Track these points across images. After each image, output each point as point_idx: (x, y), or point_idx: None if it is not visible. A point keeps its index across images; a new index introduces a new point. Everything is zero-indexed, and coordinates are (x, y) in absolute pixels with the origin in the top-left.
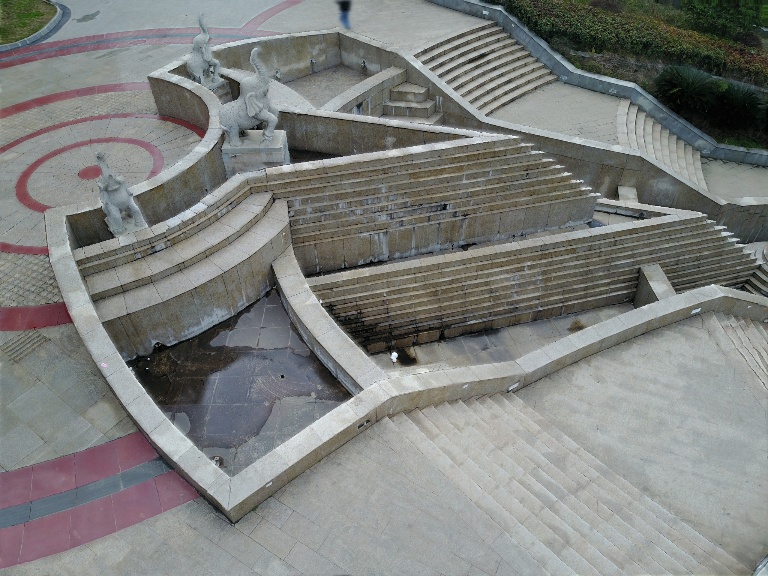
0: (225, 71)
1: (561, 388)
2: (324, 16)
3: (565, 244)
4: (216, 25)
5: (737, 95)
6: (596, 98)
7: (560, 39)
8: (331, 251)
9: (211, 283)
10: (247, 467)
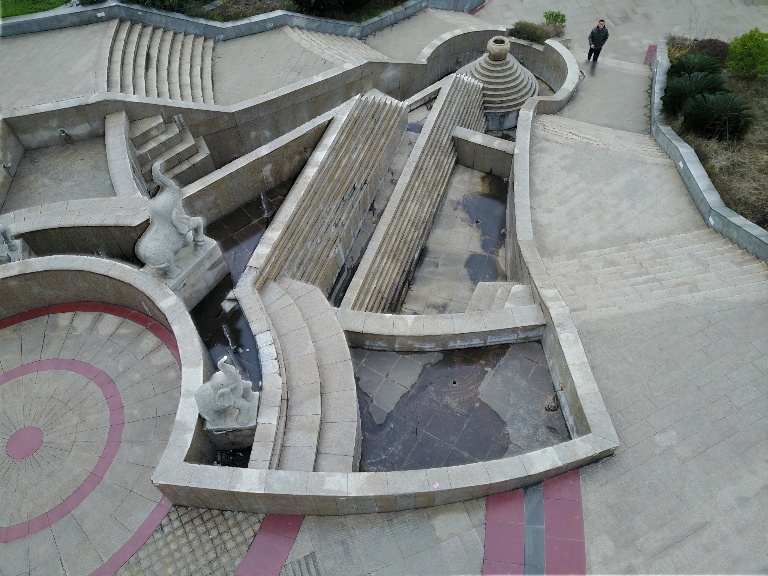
0: None
1: (544, 233)
2: None
3: (422, 153)
4: None
5: None
6: (264, 39)
7: (190, 4)
8: None
9: None
10: (587, 419)
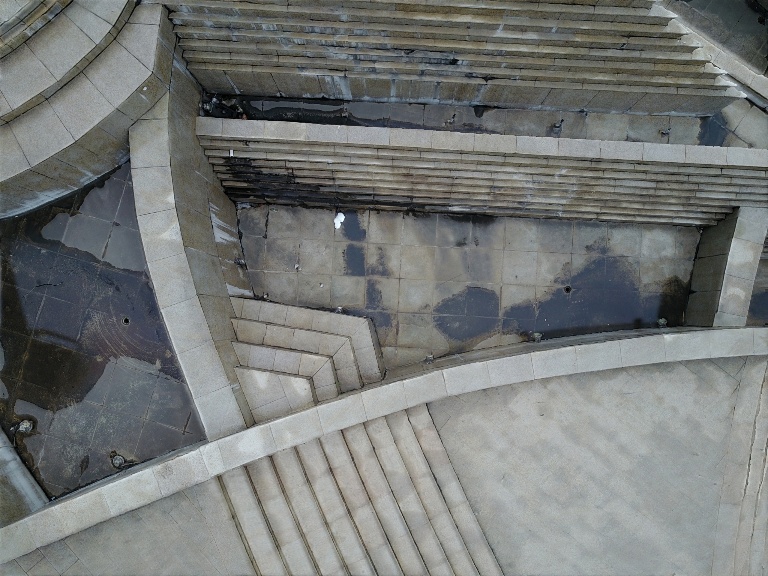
0: None
1: (491, 409)
2: None
3: (635, 162)
4: None
5: None
6: None
7: None
8: (254, 80)
9: (13, 178)
10: (18, 522)
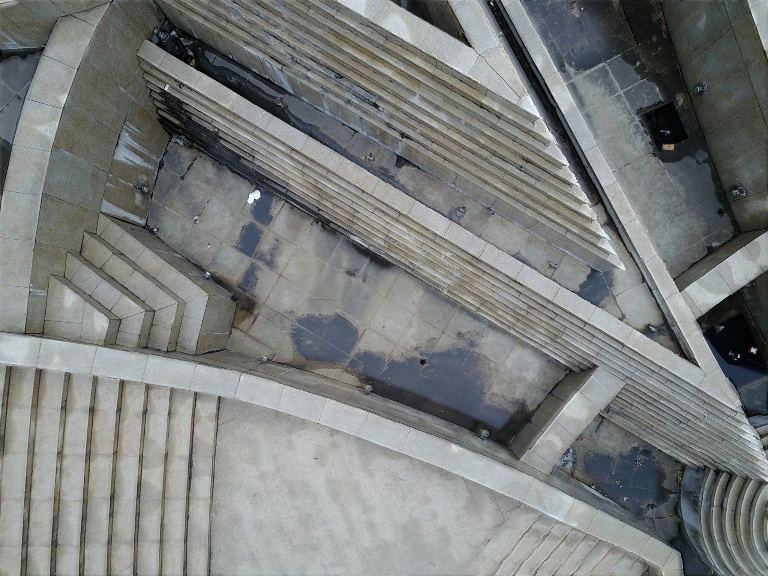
0: None
1: (274, 430)
2: None
3: None
4: None
5: None
6: None
7: None
8: (207, 32)
9: None
10: None
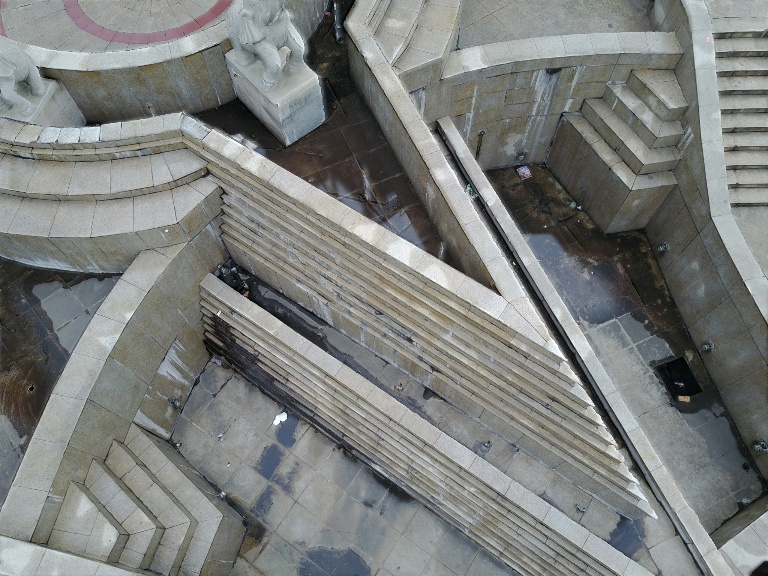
0: None
1: None
2: None
3: (537, 519)
4: None
5: None
6: None
7: None
8: (264, 270)
9: (32, 237)
10: None
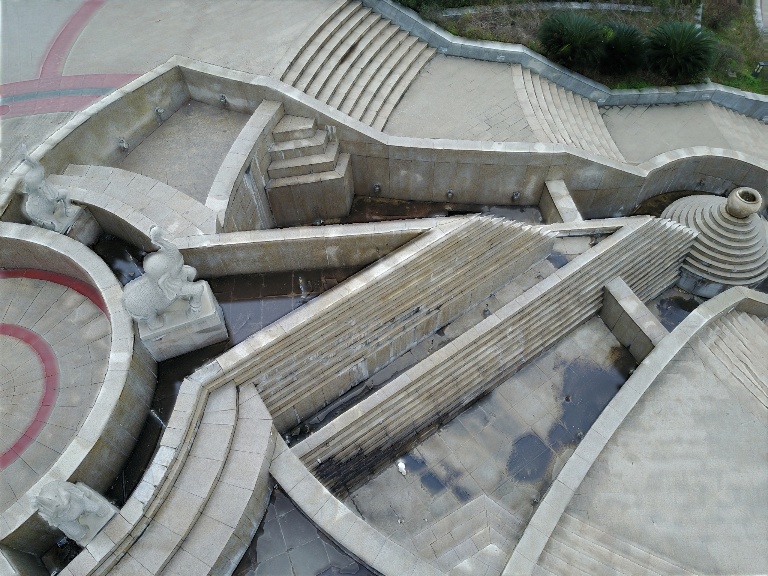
0: (76, 193)
1: (603, 485)
2: (140, 31)
3: (539, 297)
4: (2, 80)
5: (621, 36)
6: (486, 70)
7: (429, 5)
8: (311, 402)
9: (224, 548)
10: None
